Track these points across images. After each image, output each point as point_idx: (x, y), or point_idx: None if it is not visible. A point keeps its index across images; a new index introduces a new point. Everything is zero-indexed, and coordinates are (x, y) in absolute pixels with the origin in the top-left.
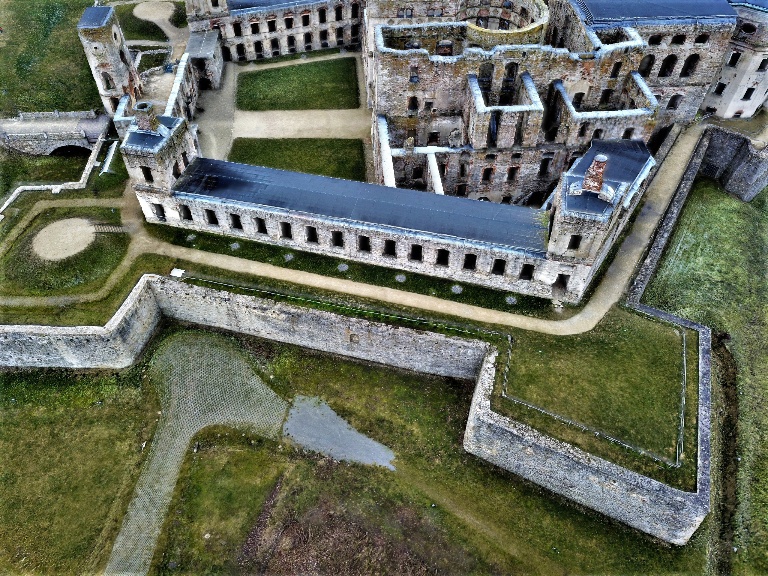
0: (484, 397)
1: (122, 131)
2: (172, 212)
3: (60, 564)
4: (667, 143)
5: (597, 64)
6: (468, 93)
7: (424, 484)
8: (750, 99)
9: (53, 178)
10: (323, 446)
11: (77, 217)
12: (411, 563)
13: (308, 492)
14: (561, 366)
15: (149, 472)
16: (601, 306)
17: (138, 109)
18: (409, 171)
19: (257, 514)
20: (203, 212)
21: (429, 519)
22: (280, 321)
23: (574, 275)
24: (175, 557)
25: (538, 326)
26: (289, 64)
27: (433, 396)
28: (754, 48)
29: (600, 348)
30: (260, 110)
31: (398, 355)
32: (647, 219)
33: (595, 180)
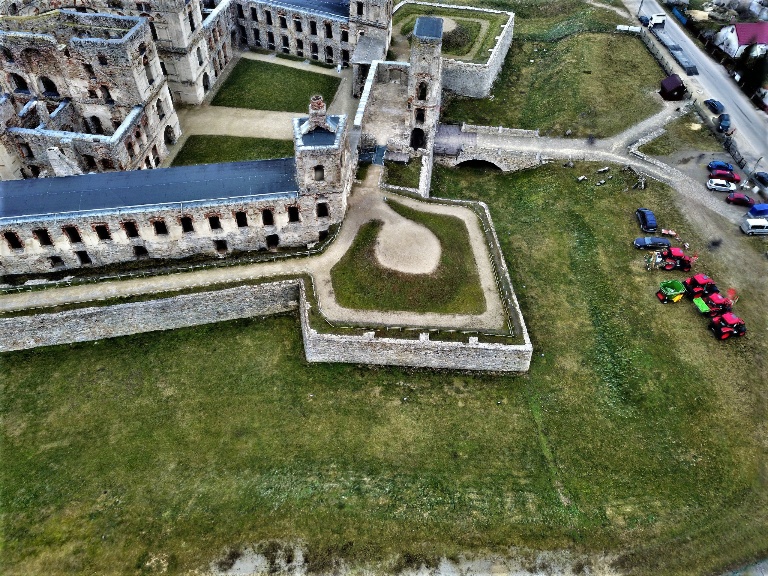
0: None
1: None
2: None
3: None
4: None
5: None
6: None
7: None
8: None
9: None
10: None
11: None
12: None
13: None
14: None
15: None
16: None
17: None
18: None
19: None
20: None
21: None
22: None
23: None
24: None
25: None
26: None
27: None
28: None
29: None
30: None
31: None
32: None
33: None
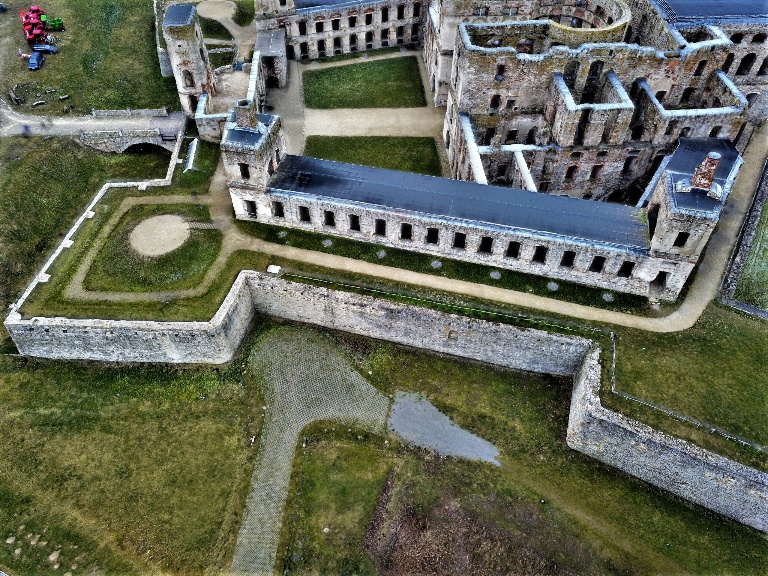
0: (593, 393)
1: (203, 129)
2: (264, 209)
3: (185, 557)
4: (742, 142)
5: (682, 62)
6: (554, 91)
7: (531, 480)
8: None
9: (129, 175)
10: (428, 442)
11: (169, 214)
12: (530, 558)
13: (421, 487)
14: (667, 363)
15: (262, 466)
16: (698, 304)
17: (240, 106)
18: (494, 169)
19: (373, 509)
20: (296, 209)
21: (540, 515)
22: (378, 317)
23: (676, 272)
24: (297, 551)
25: (638, 323)
26: (351, 63)
27: (532, 393)
28: None
29: (703, 345)
30: (329, 108)
31: (496, 352)
32: (732, 217)
33: (706, 177)
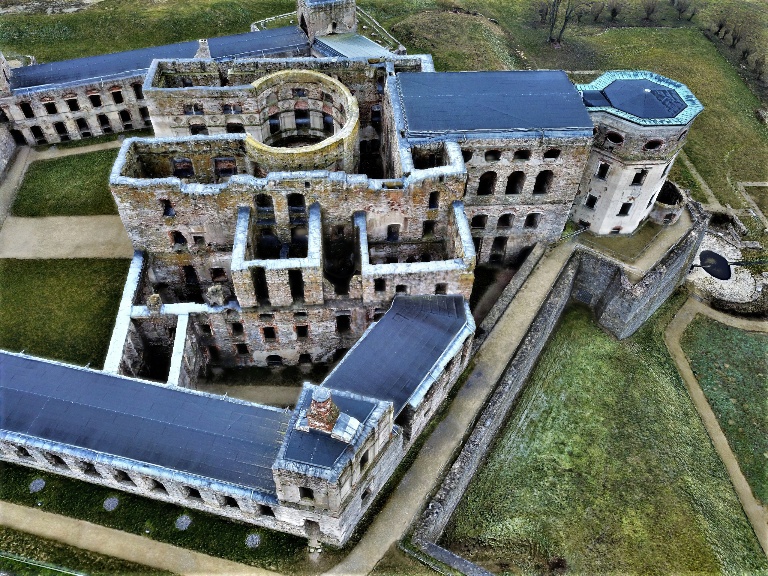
0: None
1: None
2: None
3: None
4: (522, 273)
5: (407, 194)
6: None
7: None
8: (628, 214)
9: None
10: None
11: None
12: None
13: None
14: None
15: None
16: (375, 548)
17: None
18: (162, 332)
19: None
20: None
21: None
22: None
23: (322, 522)
24: None
25: None
26: (99, 148)
27: None
28: (623, 161)
29: None
30: (39, 216)
31: None
32: (472, 393)
33: (319, 420)
